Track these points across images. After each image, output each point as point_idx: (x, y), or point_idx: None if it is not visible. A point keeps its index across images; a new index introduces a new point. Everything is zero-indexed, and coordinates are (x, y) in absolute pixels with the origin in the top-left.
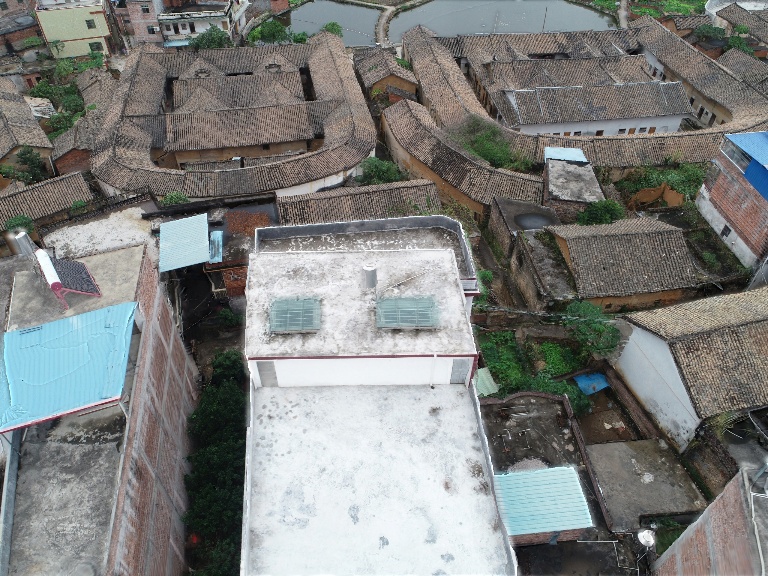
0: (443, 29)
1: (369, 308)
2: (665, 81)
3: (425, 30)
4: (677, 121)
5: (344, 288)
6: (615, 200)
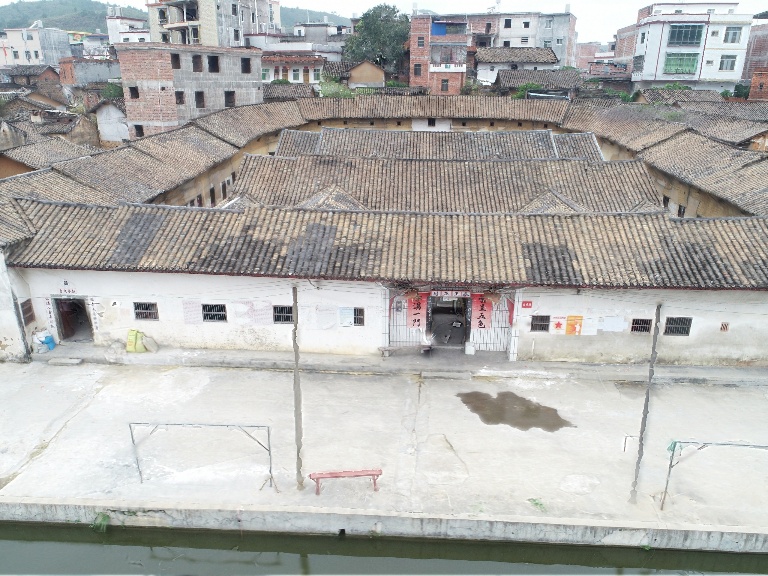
0: None
1: None
2: None
3: None
4: None
5: None
6: None
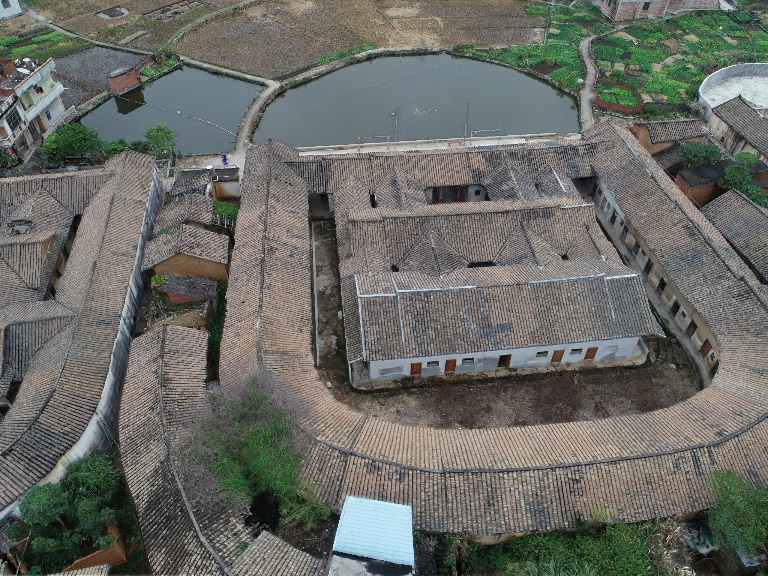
0: (336, 120)
1: None
2: (627, 235)
3: (277, 148)
4: (632, 339)
5: None
6: None
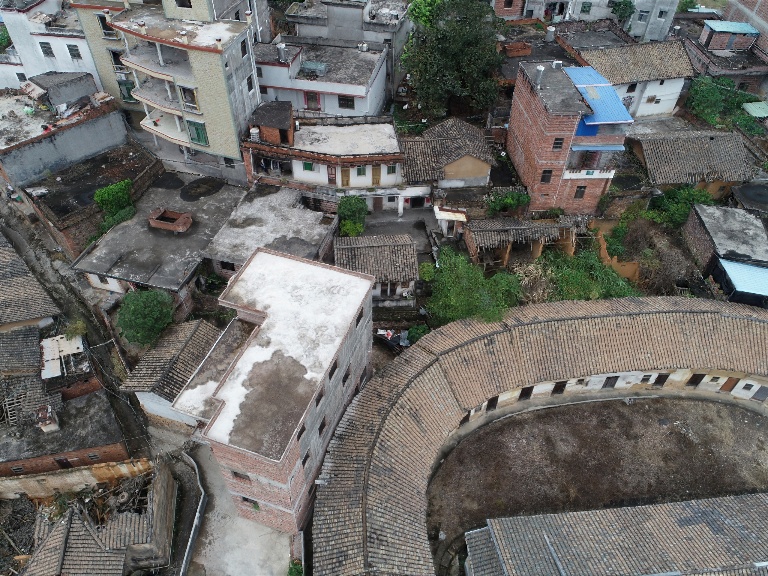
0: None
1: None
2: None
3: None
4: None
5: None
6: (669, 253)
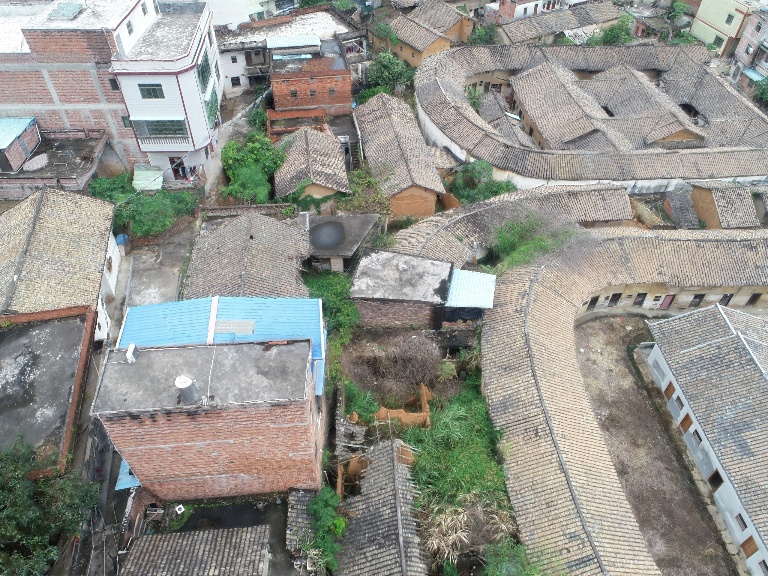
0: None
1: (82, 5)
2: None
3: None
4: None
5: (104, 0)
6: (401, 348)
